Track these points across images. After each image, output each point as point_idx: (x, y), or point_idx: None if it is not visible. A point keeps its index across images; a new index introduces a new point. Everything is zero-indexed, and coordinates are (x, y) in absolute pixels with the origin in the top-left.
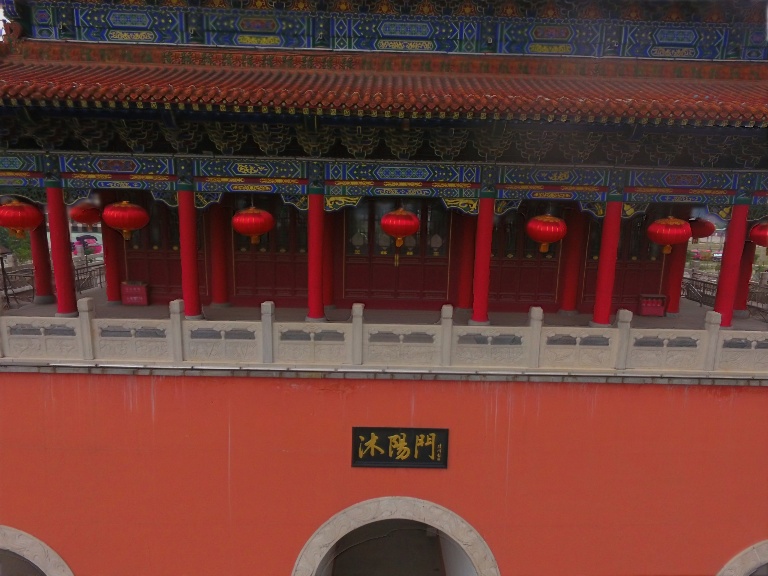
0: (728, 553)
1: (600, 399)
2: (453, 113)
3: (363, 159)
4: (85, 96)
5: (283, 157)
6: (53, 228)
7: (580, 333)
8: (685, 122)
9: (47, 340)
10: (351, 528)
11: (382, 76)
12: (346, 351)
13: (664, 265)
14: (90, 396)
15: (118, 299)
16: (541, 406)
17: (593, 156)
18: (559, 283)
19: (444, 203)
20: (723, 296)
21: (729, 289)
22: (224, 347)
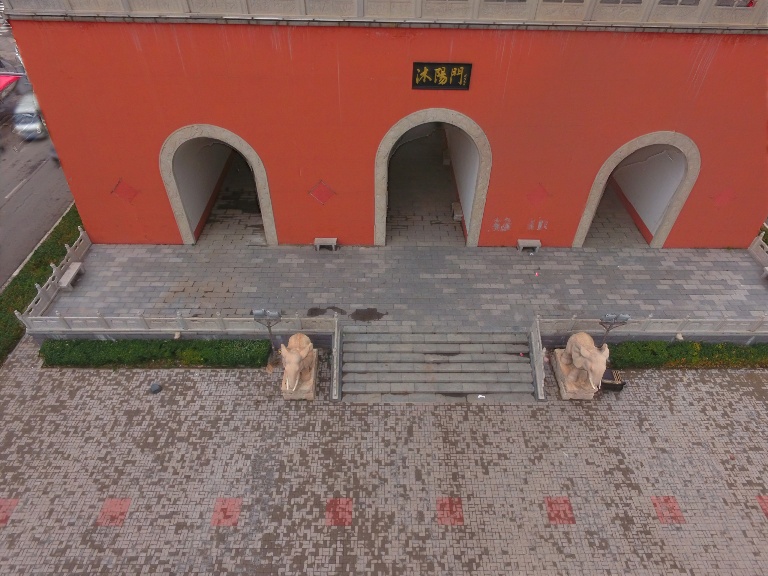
0: (622, 142)
1: (569, 43)
2: None
3: None
4: None
5: None
6: None
7: None
8: None
9: None
10: (410, 127)
11: None
12: (411, 7)
13: None
14: (250, 41)
15: None
16: (531, 48)
17: None
18: None
19: None
20: None
21: None
22: (332, 4)
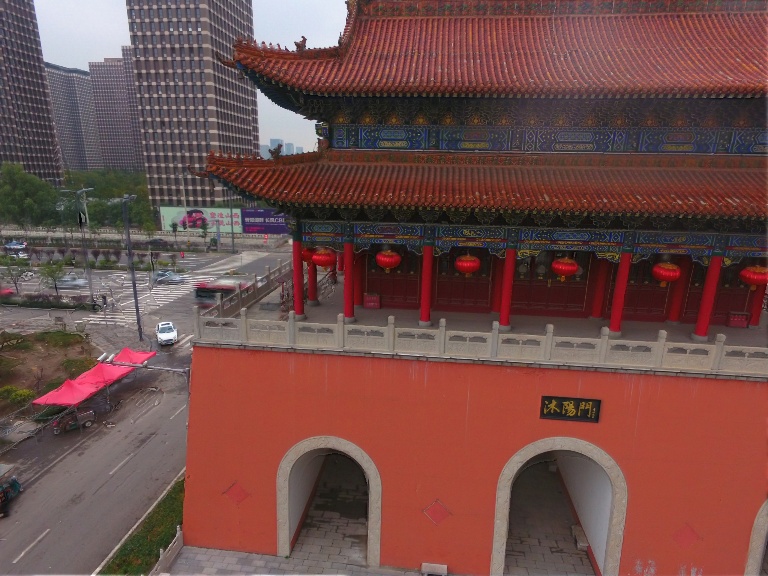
0: None
1: (700, 387)
2: (618, 213)
3: (545, 227)
4: (399, 204)
5: (493, 226)
6: (348, 267)
7: (690, 347)
8: None
9: (368, 339)
10: (537, 453)
11: (558, 170)
12: (540, 352)
13: (750, 291)
14: (391, 371)
15: (361, 304)
16: (661, 390)
17: (704, 226)
18: (667, 302)
19: (596, 255)
20: None
21: None
22: (468, 346)
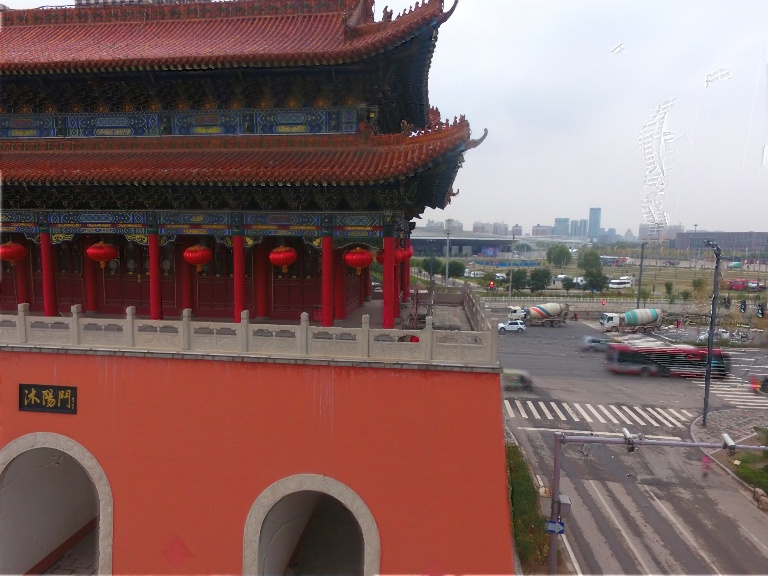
0: (265, 486)
1: (171, 370)
2: (77, 182)
3: (70, 209)
4: None
5: (22, 209)
6: None
7: (158, 324)
8: (220, 184)
9: None
10: (19, 452)
11: (92, 154)
12: (17, 334)
13: None
14: None
15: None
16: (134, 373)
17: (220, 204)
18: (254, 296)
19: (126, 238)
20: (322, 304)
21: (325, 298)
22: None
